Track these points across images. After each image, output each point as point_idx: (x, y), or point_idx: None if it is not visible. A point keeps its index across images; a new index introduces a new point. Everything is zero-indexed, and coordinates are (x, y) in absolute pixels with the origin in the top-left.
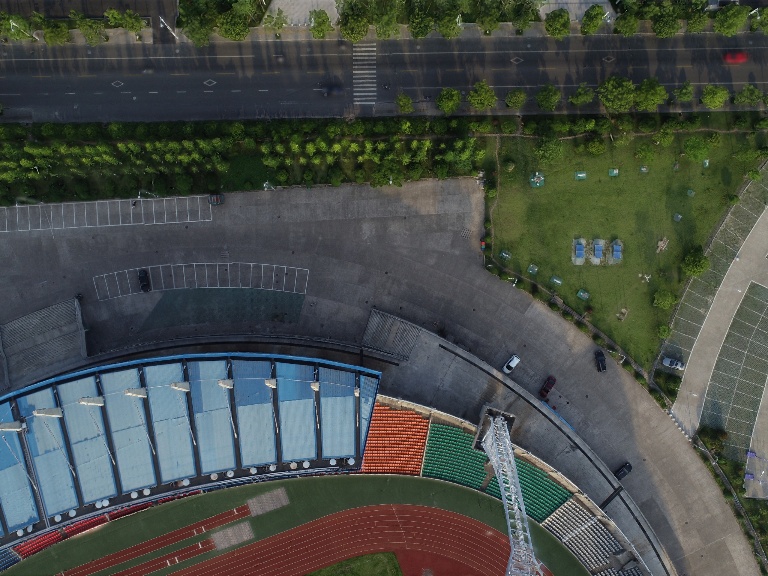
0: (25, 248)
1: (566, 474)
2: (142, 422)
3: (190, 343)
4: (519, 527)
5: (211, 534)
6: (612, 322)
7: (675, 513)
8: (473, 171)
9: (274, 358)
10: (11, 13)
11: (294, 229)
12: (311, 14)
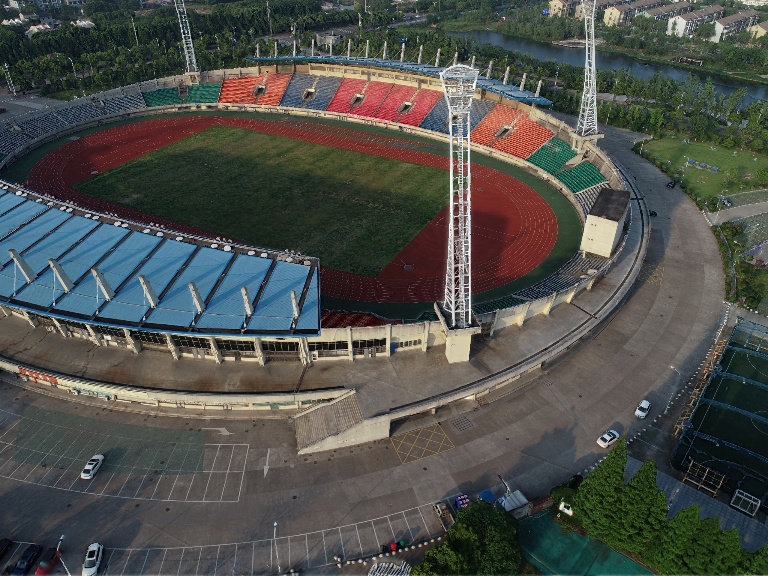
0: None
1: None
2: None
3: None
4: None
5: None
6: None
7: None
8: (652, 130)
9: None
10: None
11: None
12: None
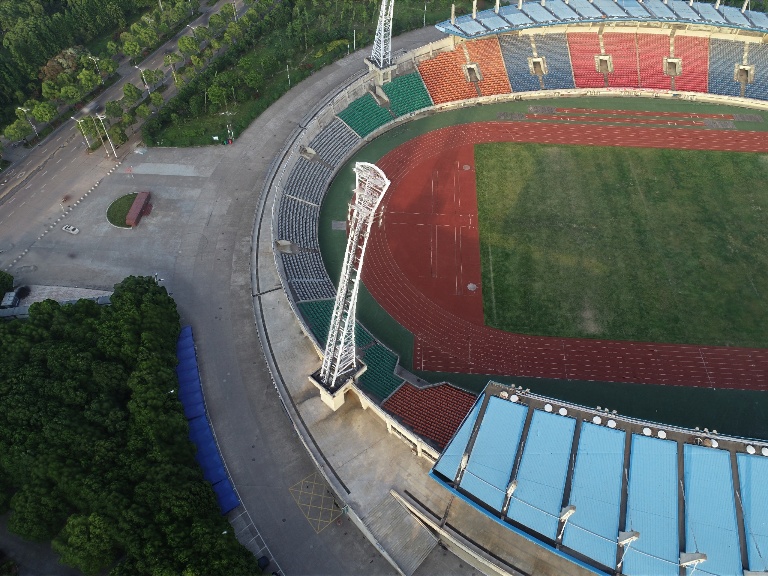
0: None
1: None
2: None
3: None
4: None
5: (703, 120)
6: None
7: None
8: None
9: None
10: None
11: None
12: None
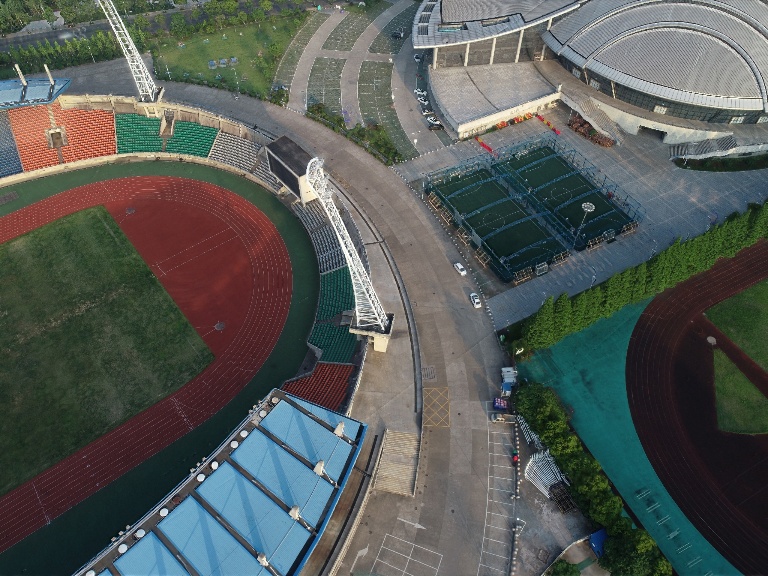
0: None
1: None
2: None
3: None
4: (109, 7)
5: None
6: (239, 83)
7: (306, 145)
8: (143, 48)
9: None
10: None
11: None
12: None
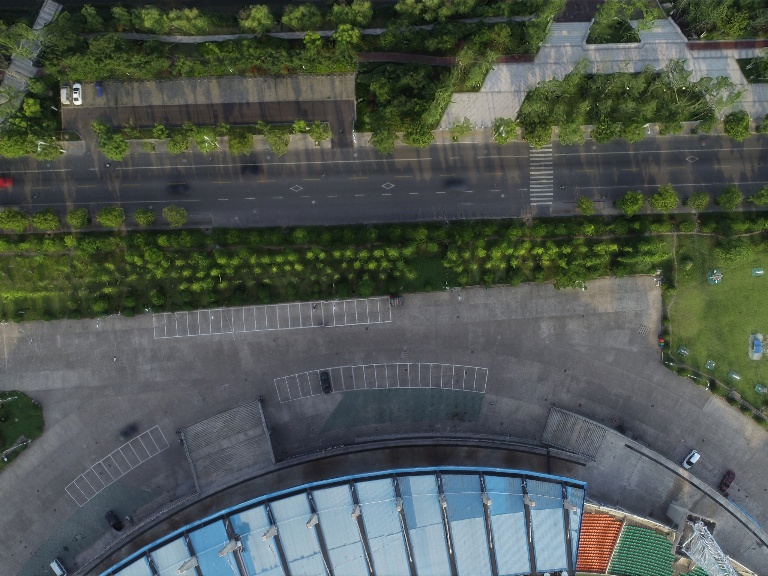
0: (207, 352)
1: (753, 571)
2: None
3: (378, 447)
4: None
5: None
6: None
7: None
8: (652, 270)
9: (482, 471)
10: (191, 120)
11: (473, 329)
12: (496, 121)
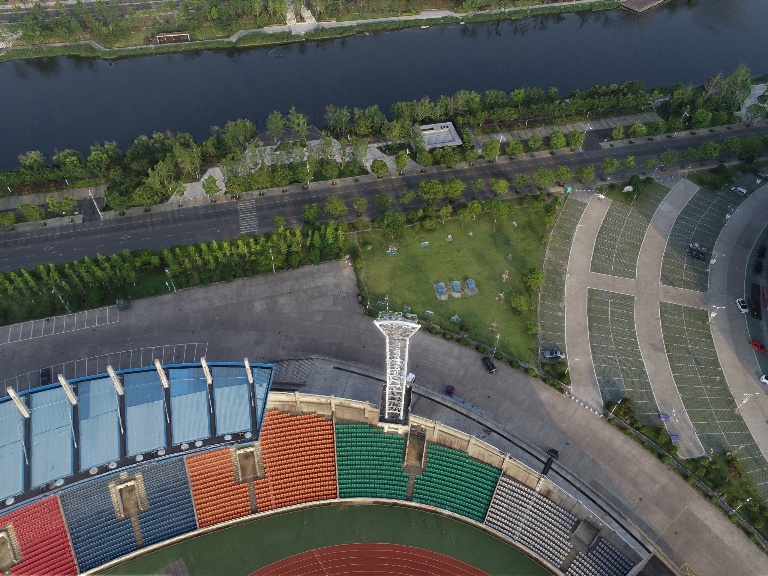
0: None
1: None
2: (20, 427)
3: None
4: None
5: None
6: (488, 334)
7: (624, 491)
8: (340, 253)
9: (167, 367)
10: None
11: (193, 316)
12: None
